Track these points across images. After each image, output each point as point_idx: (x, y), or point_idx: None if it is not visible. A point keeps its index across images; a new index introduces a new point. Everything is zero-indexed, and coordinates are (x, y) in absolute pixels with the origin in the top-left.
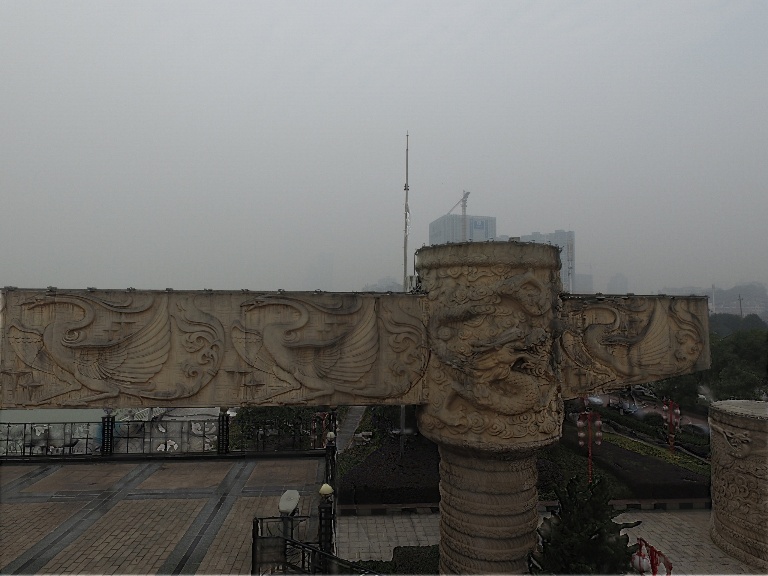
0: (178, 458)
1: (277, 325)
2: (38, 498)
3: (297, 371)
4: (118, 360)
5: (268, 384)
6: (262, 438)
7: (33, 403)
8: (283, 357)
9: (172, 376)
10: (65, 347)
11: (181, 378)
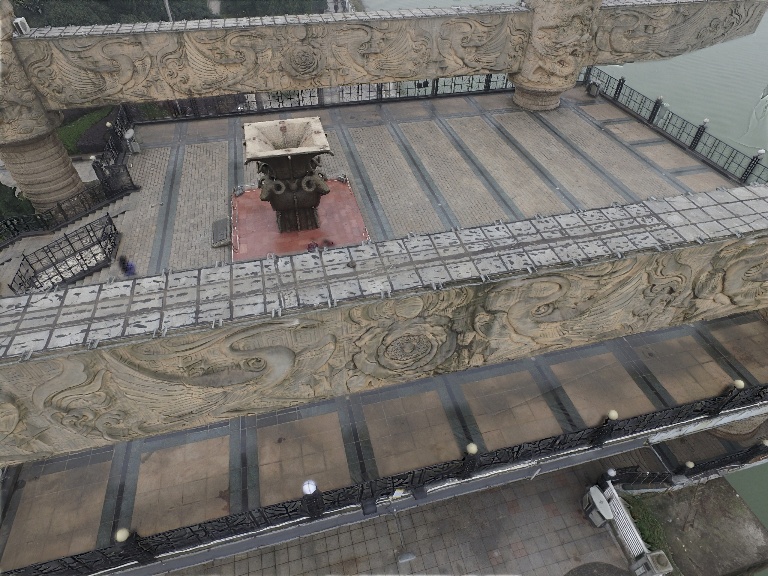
0: None
1: None
2: (308, 404)
3: None
4: None
5: None
6: (76, 567)
7: None
8: None
9: None
10: None
11: None
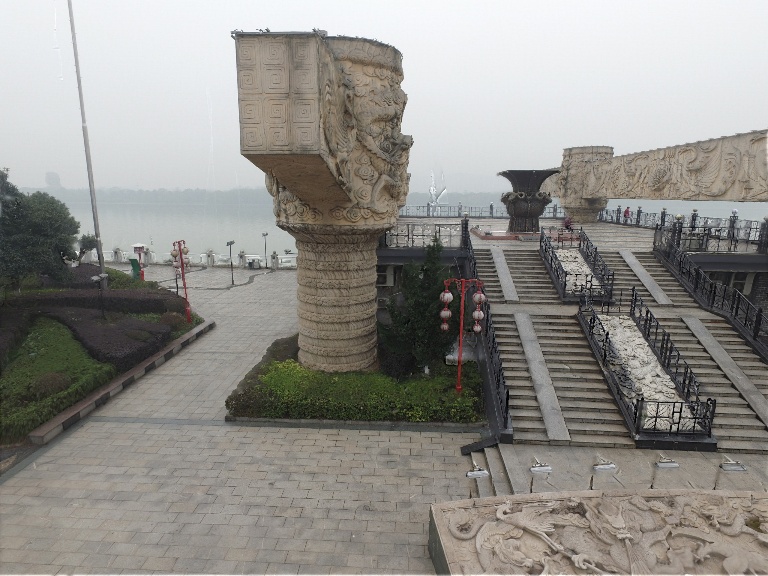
0: (757, 243)
1: (762, 151)
2: None
3: (767, 179)
4: (701, 176)
5: (755, 188)
6: None
7: (676, 197)
8: (761, 171)
9: (718, 184)
10: (686, 171)
11: (721, 185)
